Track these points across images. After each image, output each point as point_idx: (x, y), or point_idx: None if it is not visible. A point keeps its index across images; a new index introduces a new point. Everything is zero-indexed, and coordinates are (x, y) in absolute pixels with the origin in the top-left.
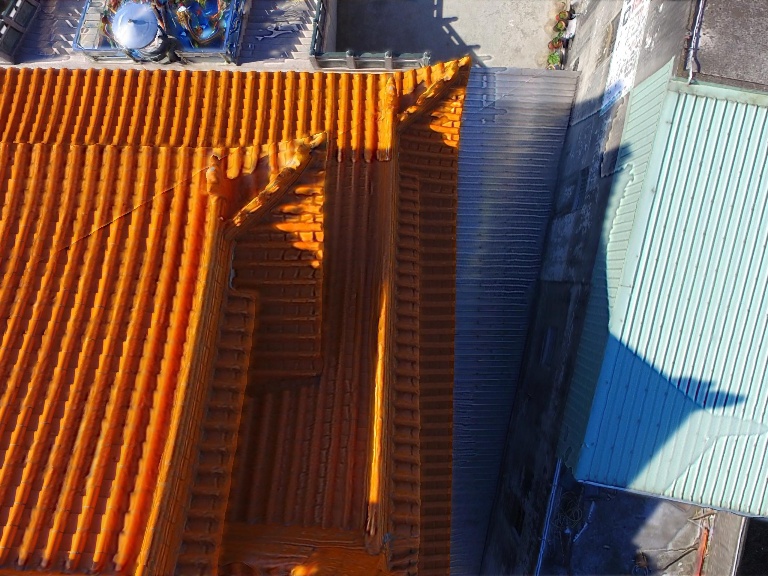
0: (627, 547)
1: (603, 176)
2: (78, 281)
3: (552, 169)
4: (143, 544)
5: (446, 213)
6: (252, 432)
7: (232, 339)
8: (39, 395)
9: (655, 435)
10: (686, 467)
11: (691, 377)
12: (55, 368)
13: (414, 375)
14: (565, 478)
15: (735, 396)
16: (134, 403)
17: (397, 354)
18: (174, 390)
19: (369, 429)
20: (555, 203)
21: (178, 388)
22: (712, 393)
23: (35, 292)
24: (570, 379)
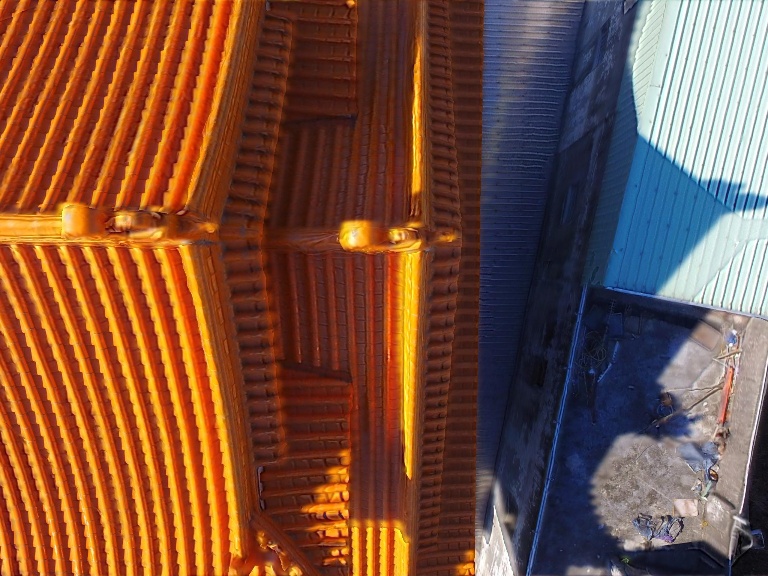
0: (652, 387)
1: (627, 11)
2: (113, 4)
3: (570, 43)
4: (191, 182)
5: (473, 17)
6: (288, 162)
7: (270, 50)
8: (78, 92)
9: (684, 240)
10: (716, 272)
11: (721, 179)
12: (93, 71)
13: (449, 122)
14: (589, 318)
15: (765, 198)
16: (174, 97)
17: (432, 104)
18: (214, 87)
19: (407, 157)
20: (573, 76)
21: (220, 70)
22: (742, 196)
23: (70, 14)
24: (595, 209)
